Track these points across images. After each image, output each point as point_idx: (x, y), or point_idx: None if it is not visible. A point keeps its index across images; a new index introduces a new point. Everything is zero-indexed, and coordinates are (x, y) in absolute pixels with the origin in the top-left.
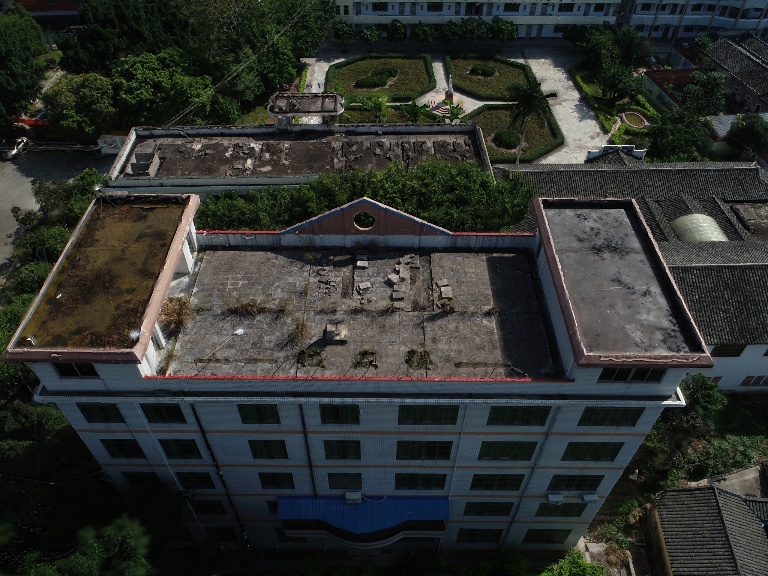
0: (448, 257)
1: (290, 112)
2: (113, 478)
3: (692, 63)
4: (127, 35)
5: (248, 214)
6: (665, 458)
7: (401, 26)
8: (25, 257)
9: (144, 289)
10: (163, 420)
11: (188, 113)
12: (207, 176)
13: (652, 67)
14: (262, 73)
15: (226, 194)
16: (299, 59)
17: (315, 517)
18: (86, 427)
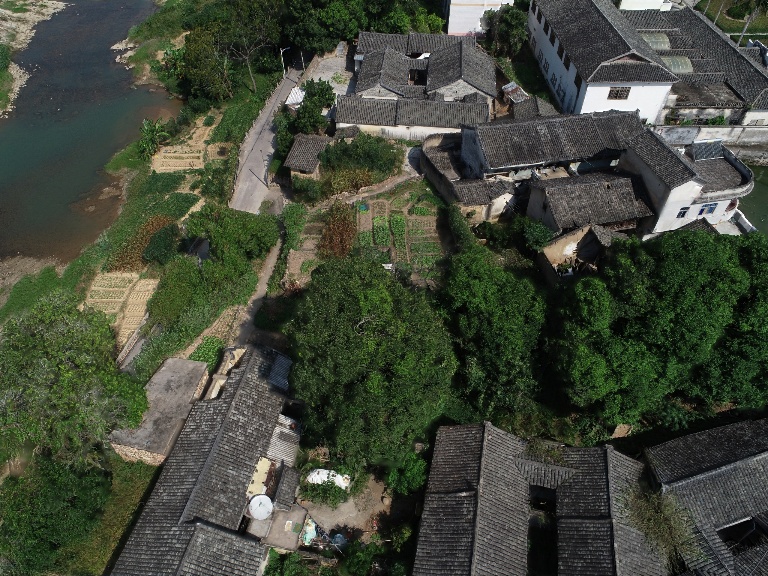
0: None
1: None
2: None
3: None
4: None
5: None
6: (484, 23)
7: None
8: None
9: None
10: None
11: None
12: None
13: None
14: None
15: None
16: None
17: None
18: None
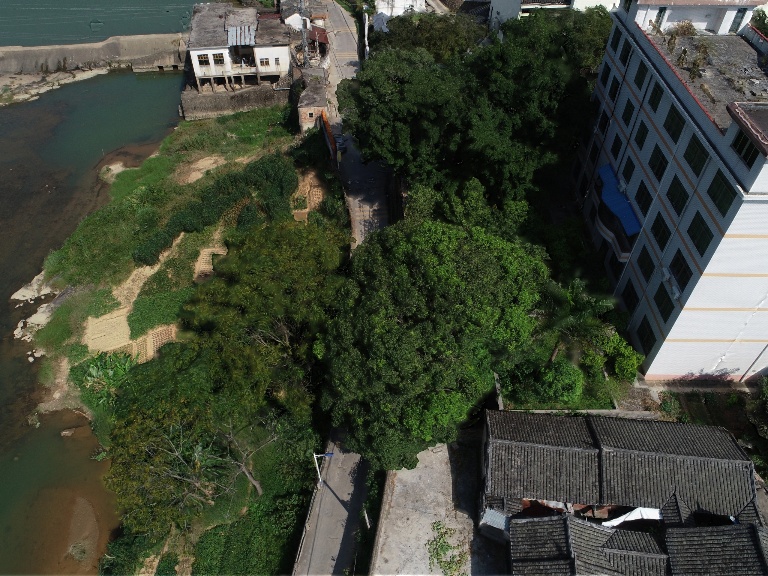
0: None
1: None
2: (592, 98)
3: None
4: None
5: None
6: (761, 416)
7: None
8: None
9: None
10: (622, 60)
11: None
12: None
13: None
14: None
15: None
16: None
17: (604, 181)
18: (608, 49)
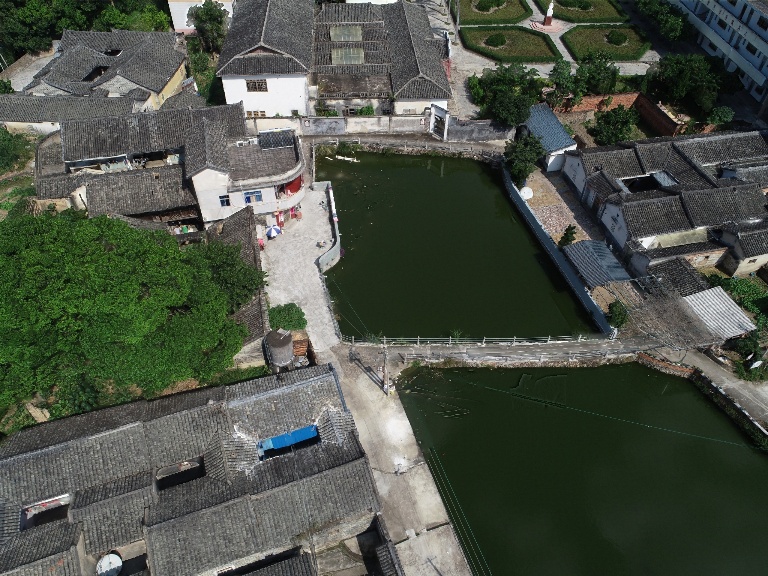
0: None
1: None
2: None
3: None
4: None
5: None
6: (190, 19)
7: None
8: None
9: None
10: None
11: None
12: None
13: None
14: None
15: None
16: None
17: None
18: None
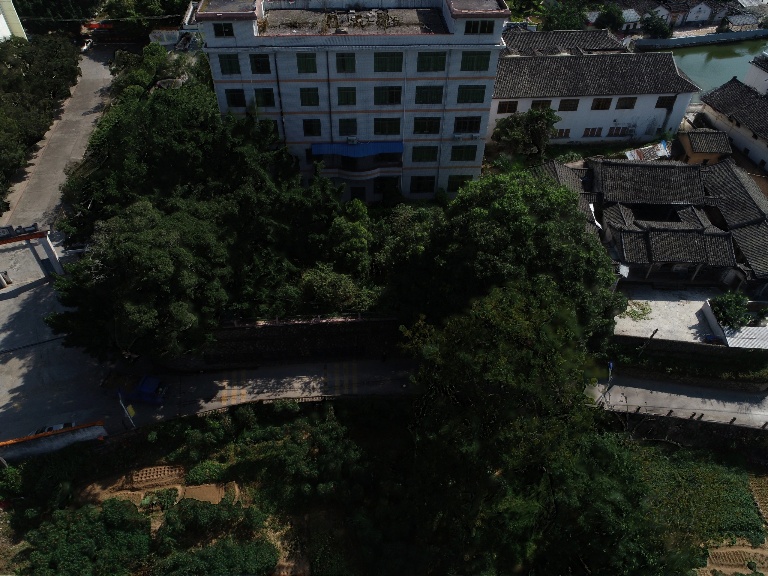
0: (397, 10)
1: None
2: None
3: None
4: None
5: None
6: (527, 148)
7: None
8: (120, 90)
9: (250, 1)
10: (259, 71)
11: None
12: None
13: None
14: None
15: None
16: None
17: (332, 152)
18: (220, 78)
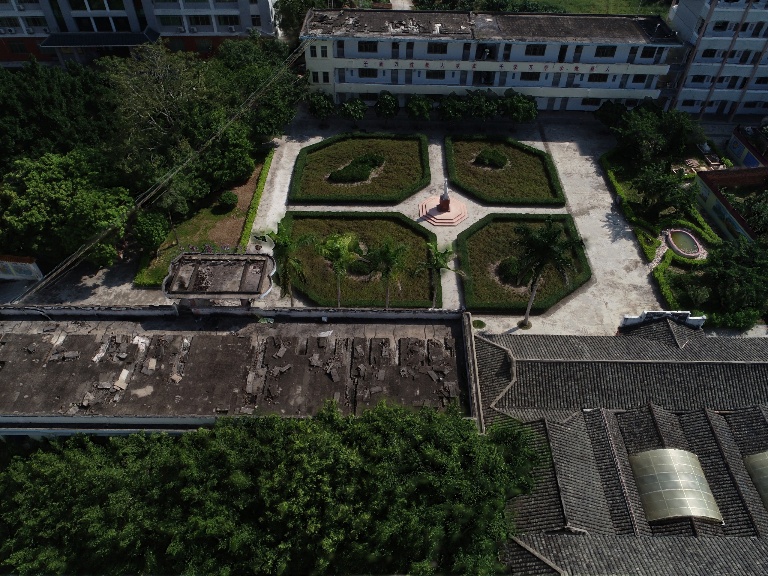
0: None
1: (193, 292)
2: None
3: (758, 159)
4: (37, 121)
5: (99, 486)
6: None
7: (391, 100)
8: None
9: None
10: None
11: (72, 264)
12: (47, 414)
13: (705, 158)
14: (205, 172)
15: (77, 439)
16: (261, 144)
17: None
18: None
